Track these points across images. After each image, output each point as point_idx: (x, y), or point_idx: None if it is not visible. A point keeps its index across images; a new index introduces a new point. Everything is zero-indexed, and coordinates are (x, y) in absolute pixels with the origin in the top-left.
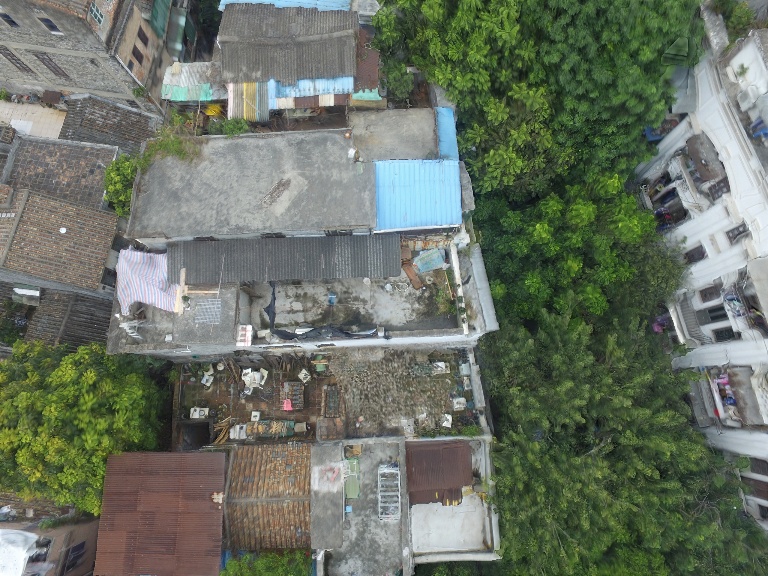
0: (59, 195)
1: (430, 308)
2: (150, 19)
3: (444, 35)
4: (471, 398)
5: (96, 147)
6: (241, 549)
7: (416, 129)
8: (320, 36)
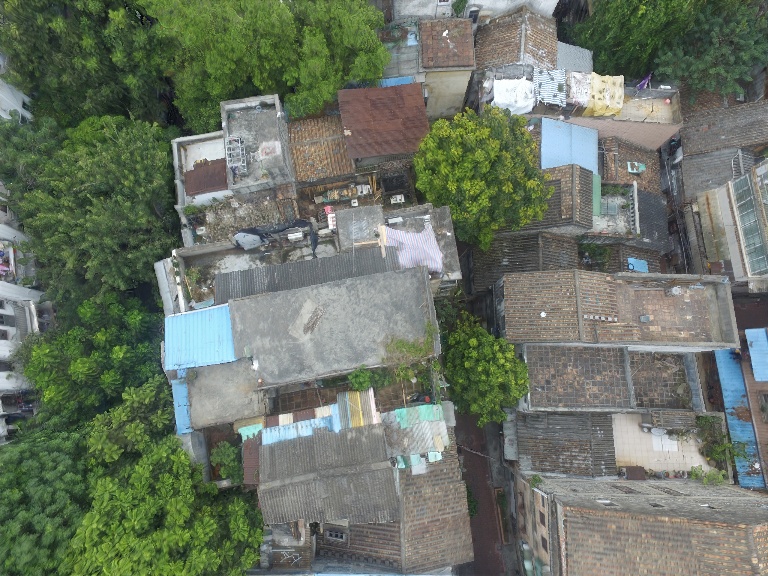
0: (570, 355)
1: (206, 272)
2: (542, 568)
3: (174, 497)
4: (195, 238)
5: (553, 408)
6: (337, 115)
7: (207, 405)
8: (293, 480)
